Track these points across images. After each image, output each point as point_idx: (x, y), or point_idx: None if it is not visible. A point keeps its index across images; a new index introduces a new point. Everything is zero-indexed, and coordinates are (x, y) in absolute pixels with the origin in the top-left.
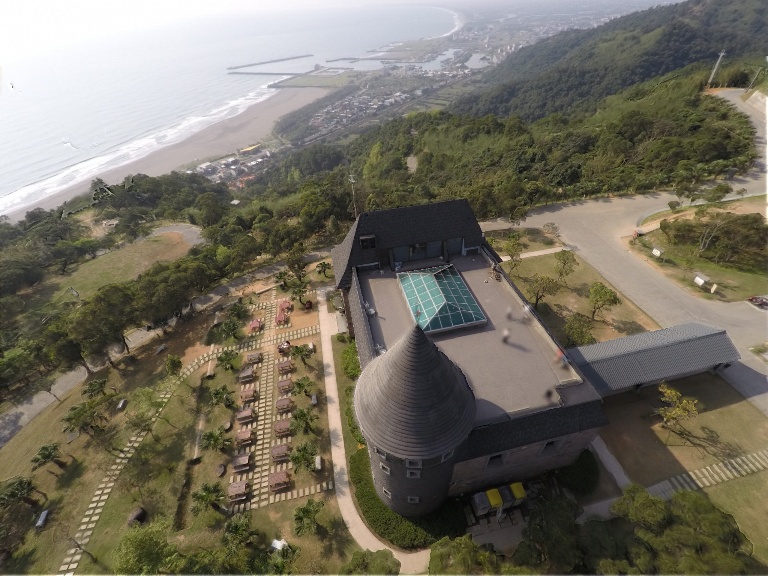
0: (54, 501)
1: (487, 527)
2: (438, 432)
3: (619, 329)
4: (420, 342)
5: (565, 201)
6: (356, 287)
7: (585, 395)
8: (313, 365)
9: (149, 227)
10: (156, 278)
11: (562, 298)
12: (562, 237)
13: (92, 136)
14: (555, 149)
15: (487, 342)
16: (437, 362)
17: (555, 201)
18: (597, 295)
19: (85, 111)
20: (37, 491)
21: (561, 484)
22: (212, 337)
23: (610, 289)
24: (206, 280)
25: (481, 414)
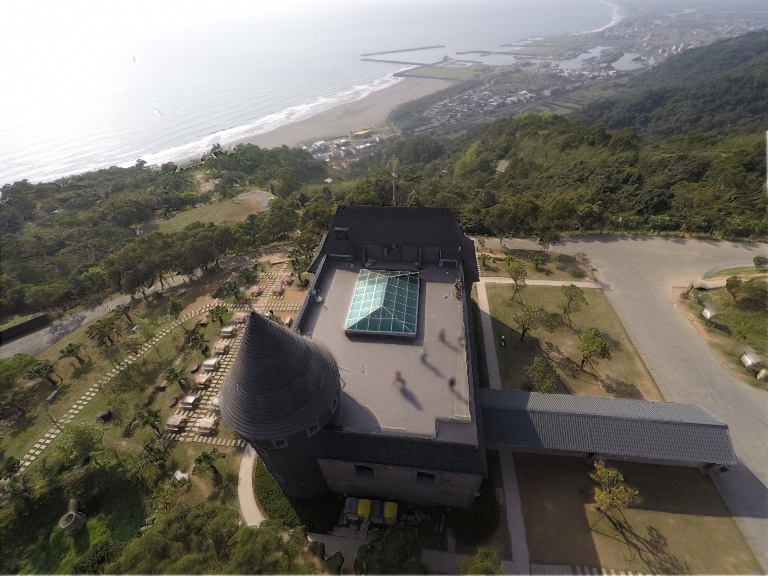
0: (64, 386)
1: (354, 533)
2: (266, 417)
3: (608, 388)
4: (254, 328)
5: (625, 233)
6: (316, 273)
7: (462, 435)
8: None
9: (241, 191)
10: (189, 232)
11: (558, 337)
12: (598, 272)
13: (178, 106)
14: (659, 172)
15: (406, 356)
16: (273, 351)
17: (613, 231)
18: (585, 342)
19: (179, 85)
20: (57, 375)
21: (447, 523)
22: (221, 292)
23: (603, 340)
24: (232, 243)
25: (356, 420)
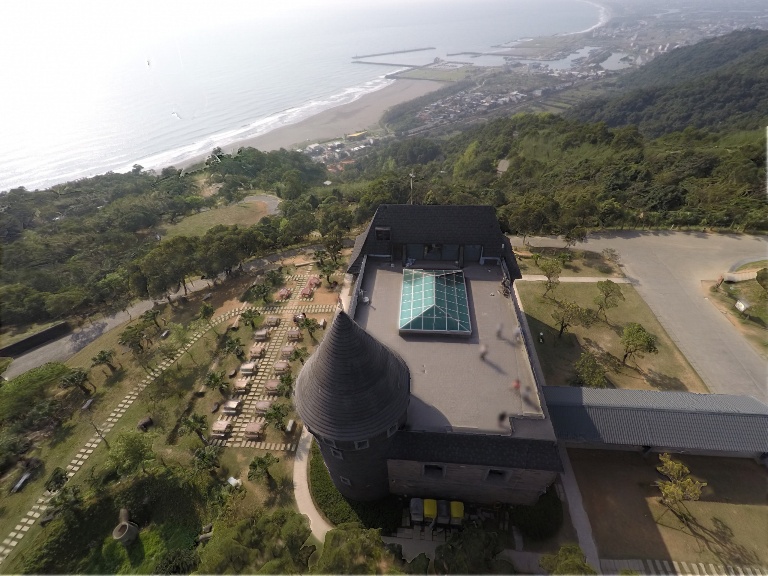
0: (99, 394)
1: (419, 534)
2: (351, 418)
3: (653, 382)
4: (342, 328)
5: (646, 228)
6: None
7: (539, 432)
8: (318, 339)
9: (245, 194)
10: (214, 236)
11: (596, 333)
12: (625, 267)
13: (195, 109)
14: (666, 169)
15: (464, 354)
16: (360, 352)
17: (633, 227)
18: (630, 337)
19: (195, 88)
20: (90, 383)
21: (512, 521)
22: (248, 296)
23: None
24: (256, 245)
25: (426, 420)
